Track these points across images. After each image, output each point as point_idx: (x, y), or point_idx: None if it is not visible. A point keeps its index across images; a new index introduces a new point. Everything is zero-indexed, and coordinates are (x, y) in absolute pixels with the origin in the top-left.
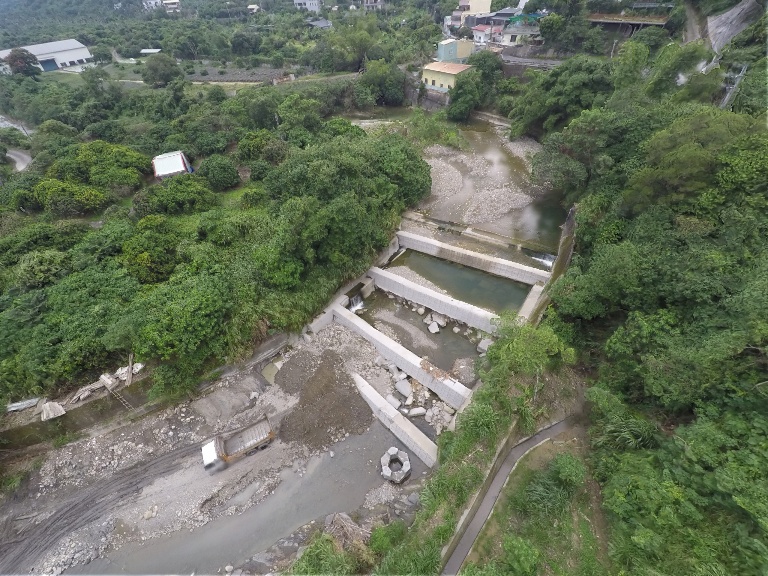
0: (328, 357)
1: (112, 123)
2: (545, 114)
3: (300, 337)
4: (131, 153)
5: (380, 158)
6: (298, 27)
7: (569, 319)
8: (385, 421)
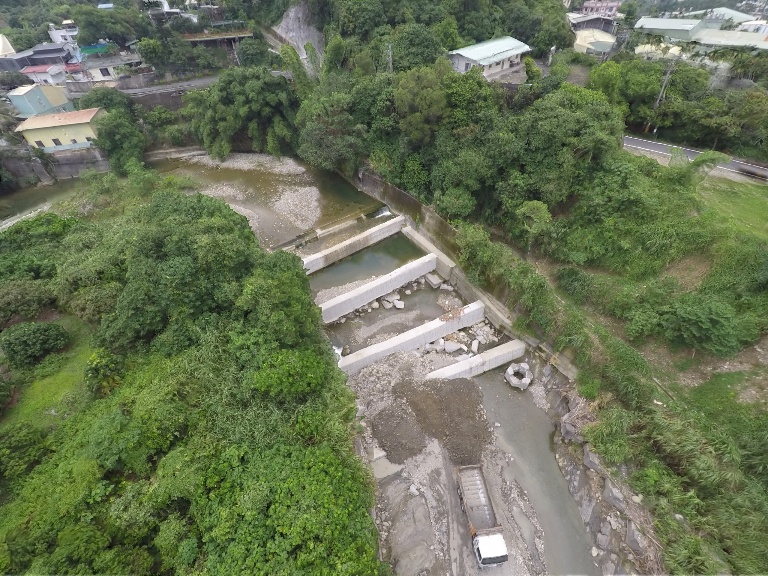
0: (404, 390)
1: None
2: (242, 125)
3: None
4: None
5: None
6: None
7: None
8: (479, 371)
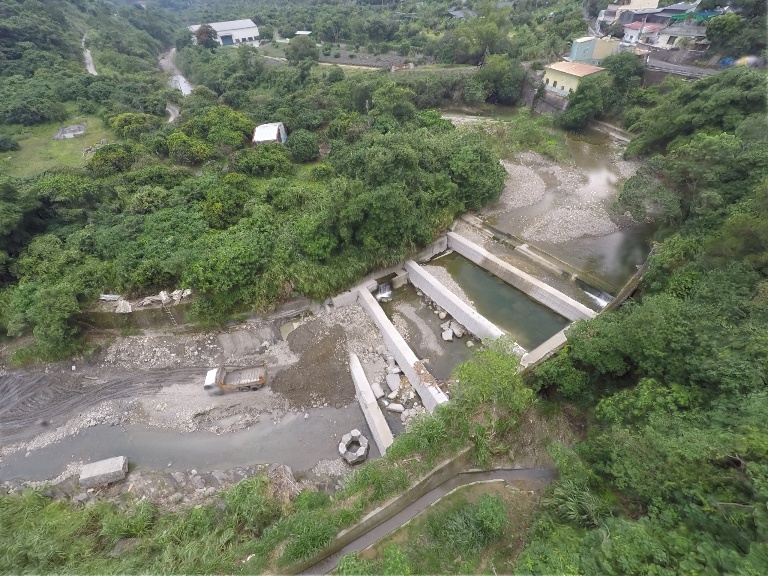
0: (335, 331)
1: (241, 92)
2: (673, 133)
3: (322, 307)
4: (243, 119)
5: (452, 155)
6: (438, 16)
7: (586, 367)
8: (362, 405)
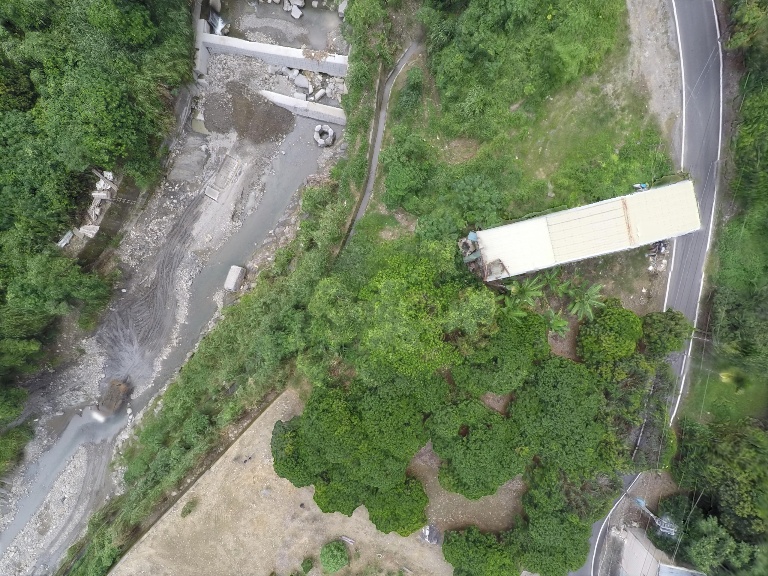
0: (233, 89)
1: None
2: None
3: (197, 85)
4: None
5: None
6: None
7: None
8: (303, 113)
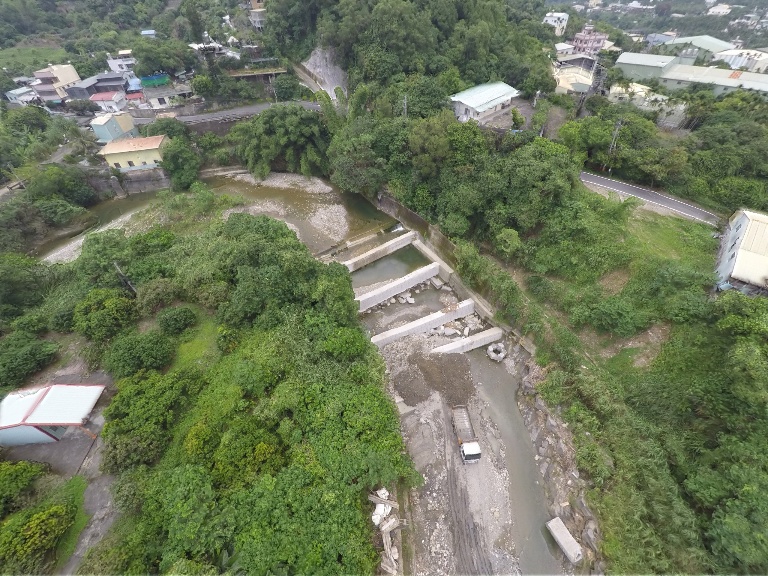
0: (415, 359)
1: None
2: (281, 151)
3: None
4: None
5: None
6: None
7: None
8: (468, 348)
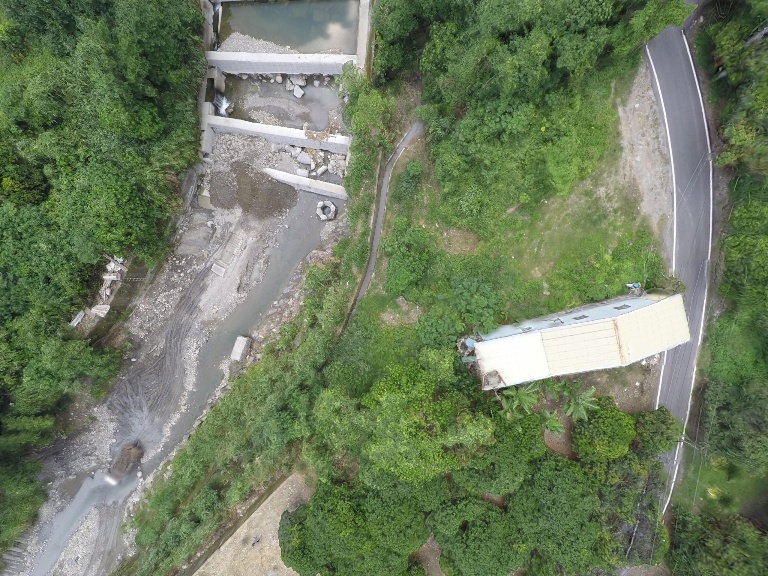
0: (237, 169)
1: None
2: None
3: (202, 163)
4: None
5: None
6: None
7: None
8: (305, 189)
